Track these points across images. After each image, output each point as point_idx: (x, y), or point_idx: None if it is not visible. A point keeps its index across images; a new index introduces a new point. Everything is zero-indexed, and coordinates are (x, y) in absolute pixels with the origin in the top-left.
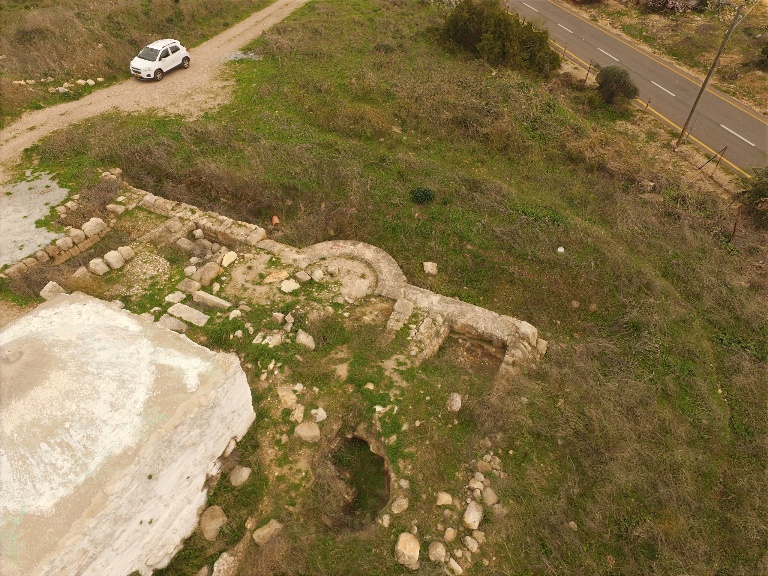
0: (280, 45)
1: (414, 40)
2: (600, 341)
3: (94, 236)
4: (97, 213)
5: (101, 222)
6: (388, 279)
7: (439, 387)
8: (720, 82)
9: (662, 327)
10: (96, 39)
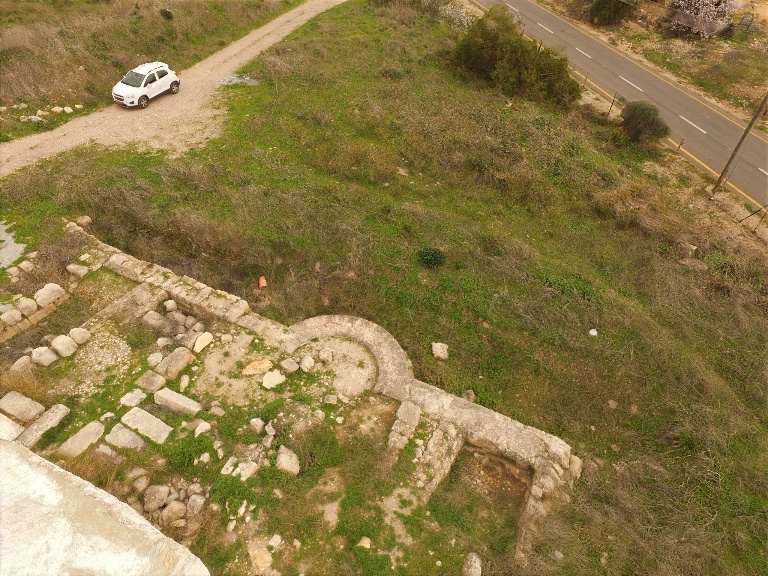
0: (278, 69)
1: (423, 64)
2: (647, 463)
3: (49, 305)
4: (54, 277)
5: (58, 289)
6: (390, 371)
7: (453, 544)
8: None
9: (721, 445)
10: (77, 61)
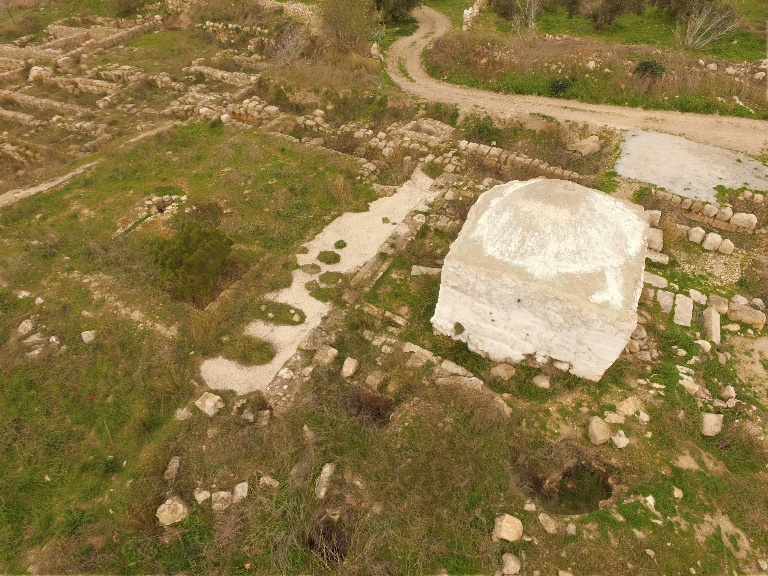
0: None
1: None
2: None
3: (734, 225)
4: (762, 216)
5: (753, 222)
6: None
7: None
8: None
9: None
10: None
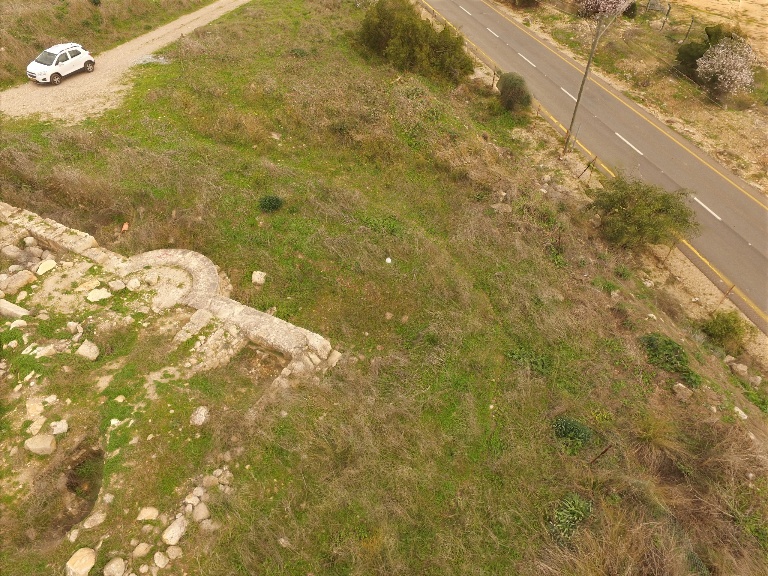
0: (188, 49)
1: (332, 44)
2: (390, 354)
3: None
4: None
5: None
6: (201, 289)
7: (190, 400)
8: (632, 89)
9: (457, 341)
10: None
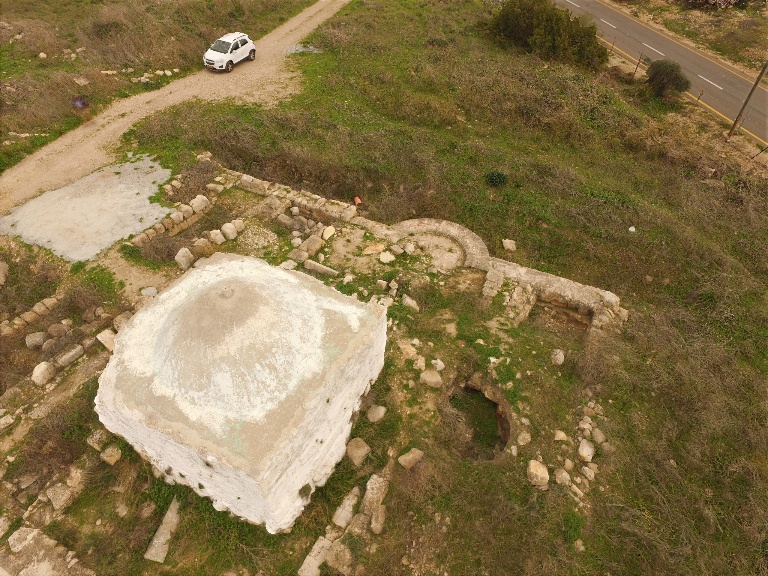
0: (339, 39)
1: (464, 34)
2: (678, 310)
3: (200, 212)
4: (201, 191)
5: (206, 199)
6: (475, 253)
7: (542, 344)
8: (766, 76)
9: (735, 299)
10: (169, 32)
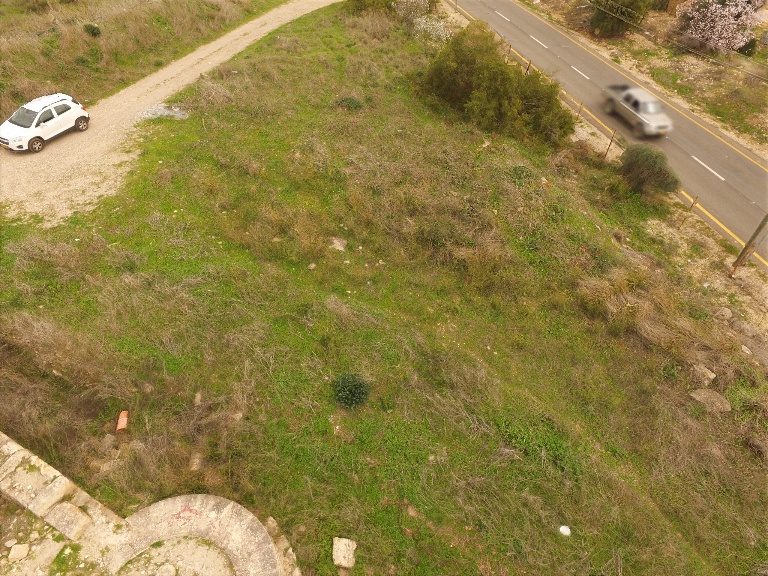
0: (211, 99)
1: (389, 90)
2: None
3: None
4: None
5: None
6: None
7: None
8: None
9: None
10: None
